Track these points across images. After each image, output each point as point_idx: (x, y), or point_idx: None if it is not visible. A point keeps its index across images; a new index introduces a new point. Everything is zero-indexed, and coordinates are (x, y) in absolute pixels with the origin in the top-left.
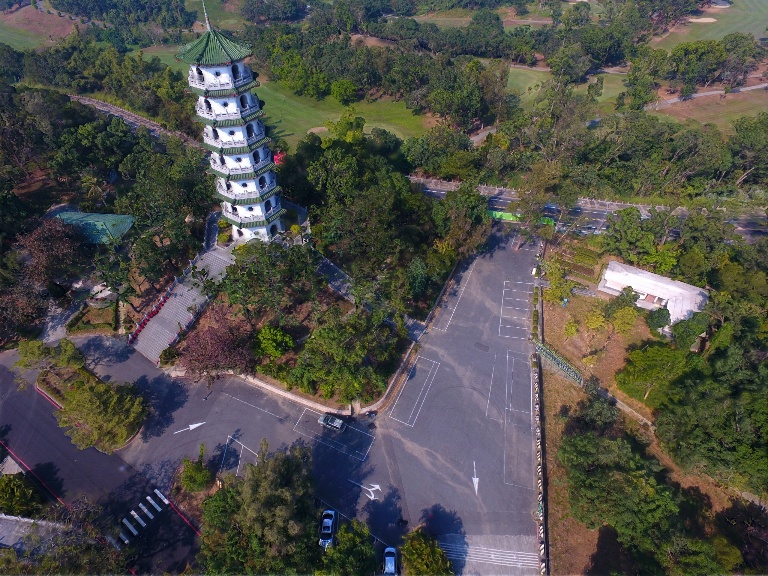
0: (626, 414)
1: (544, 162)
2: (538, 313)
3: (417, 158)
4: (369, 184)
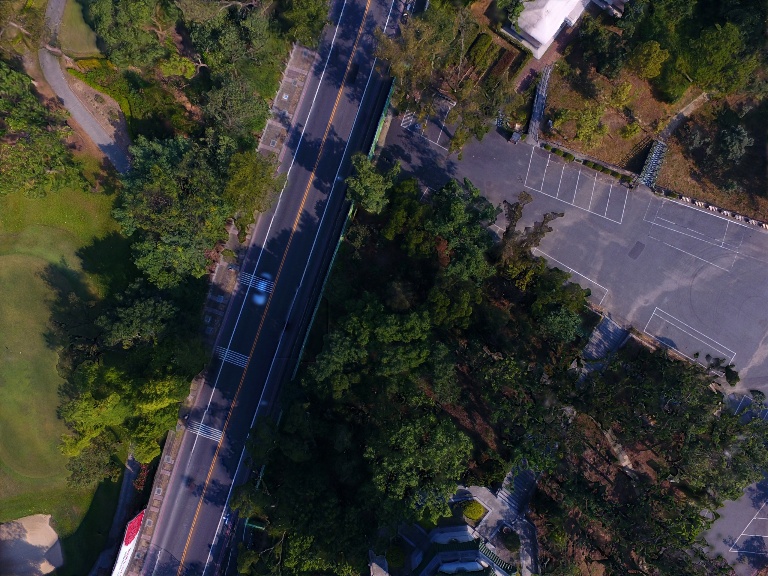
0: (697, 111)
1: (386, 43)
2: (588, 161)
3: (200, 259)
4: (414, 390)
